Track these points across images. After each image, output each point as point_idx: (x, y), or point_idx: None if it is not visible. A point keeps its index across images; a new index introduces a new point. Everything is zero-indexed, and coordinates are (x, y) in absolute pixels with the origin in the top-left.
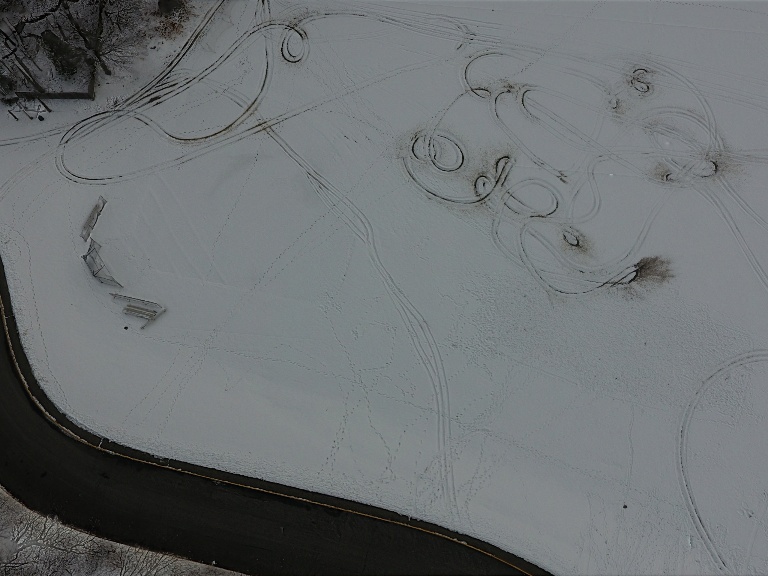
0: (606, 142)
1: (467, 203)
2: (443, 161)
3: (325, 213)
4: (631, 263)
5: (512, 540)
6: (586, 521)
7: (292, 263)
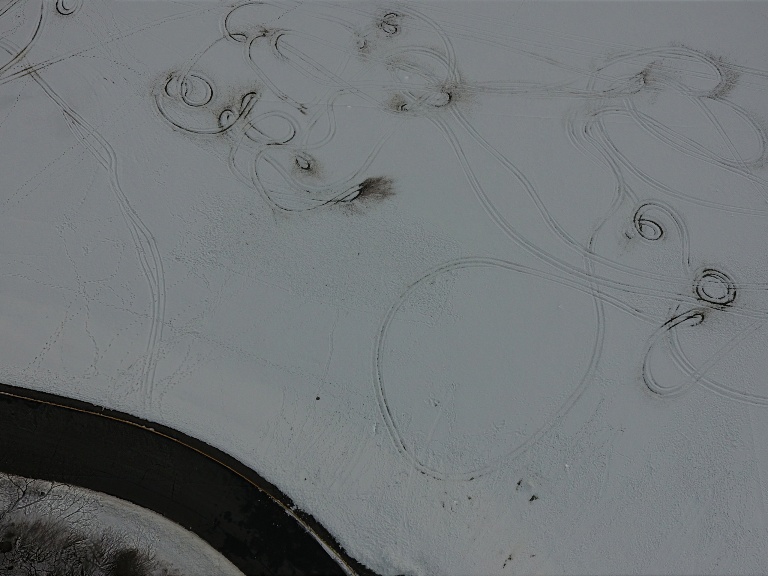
0: (349, 78)
1: (209, 134)
2: (192, 97)
3: (74, 145)
4: (356, 183)
5: (198, 426)
6: (276, 411)
7: (36, 189)
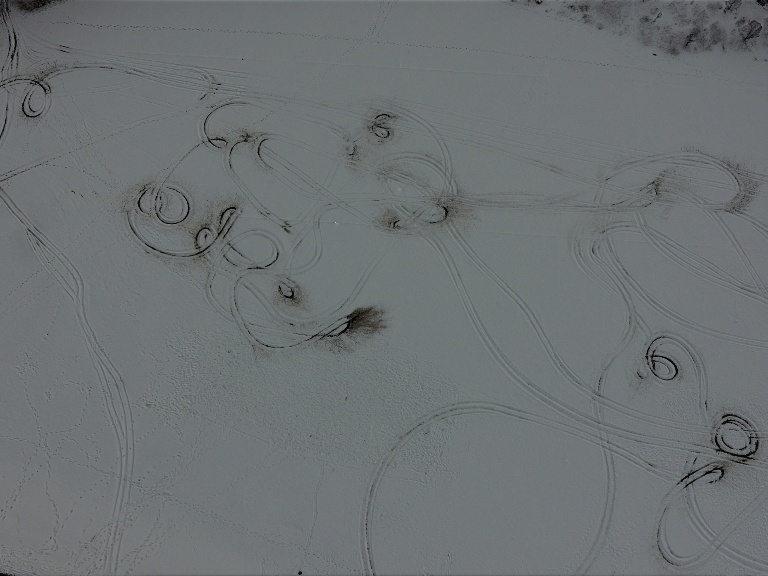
0: (337, 190)
1: (185, 256)
2: (167, 214)
3: (38, 270)
4: (344, 314)
5: None
6: None
7: None
